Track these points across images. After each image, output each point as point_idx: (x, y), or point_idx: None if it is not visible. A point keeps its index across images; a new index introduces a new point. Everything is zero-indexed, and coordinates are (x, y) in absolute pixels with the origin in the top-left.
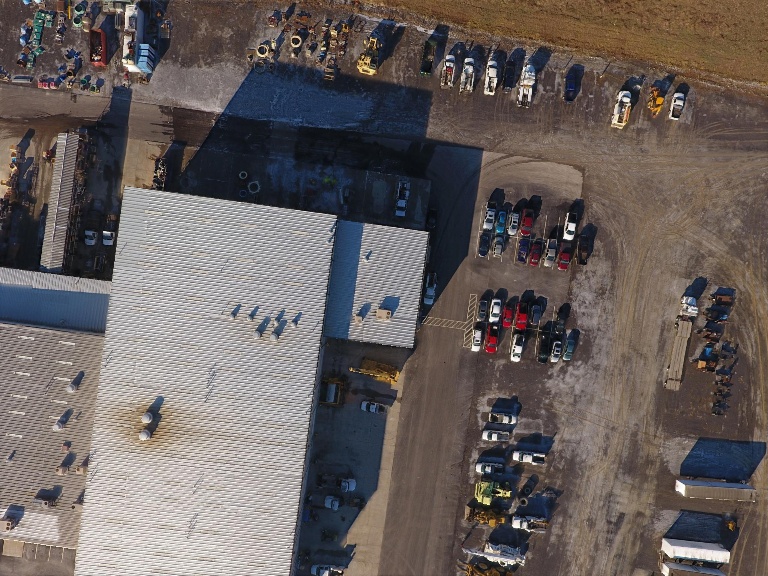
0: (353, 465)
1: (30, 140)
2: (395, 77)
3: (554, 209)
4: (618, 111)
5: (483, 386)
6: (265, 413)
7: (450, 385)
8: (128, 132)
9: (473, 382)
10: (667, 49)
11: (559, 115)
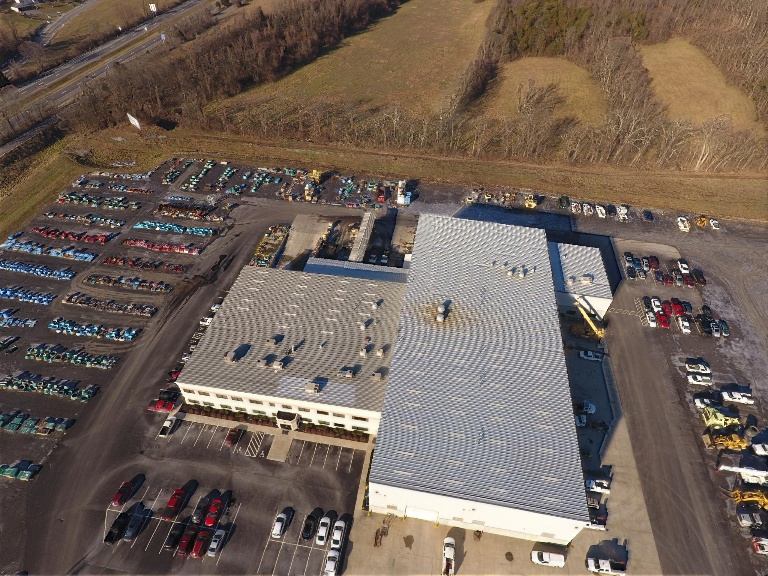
0: (586, 398)
1: (338, 224)
2: (546, 210)
3: (668, 262)
4: (682, 223)
5: (670, 350)
6: (525, 313)
7: (644, 347)
8: (396, 223)
9: (661, 347)
10: (693, 206)
11: (647, 226)
